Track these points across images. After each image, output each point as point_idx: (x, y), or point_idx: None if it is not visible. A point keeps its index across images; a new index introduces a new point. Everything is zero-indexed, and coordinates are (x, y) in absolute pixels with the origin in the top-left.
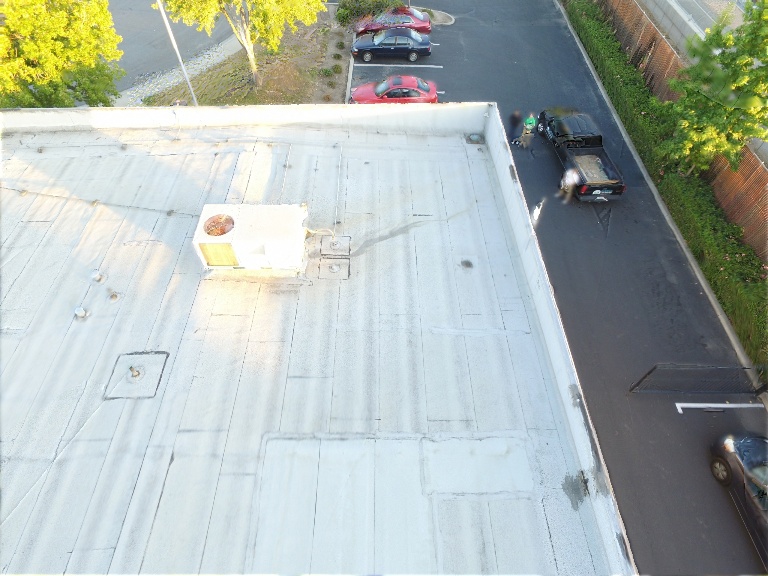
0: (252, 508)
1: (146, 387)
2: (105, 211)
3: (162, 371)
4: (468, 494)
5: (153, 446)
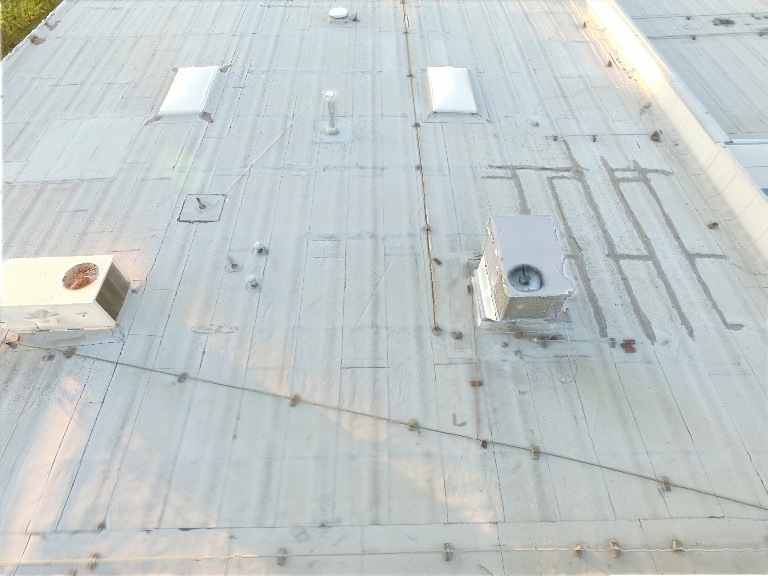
0: (129, 152)
1: (194, 200)
2: (276, 384)
3: (182, 209)
4: (3, 162)
5: (186, 171)
